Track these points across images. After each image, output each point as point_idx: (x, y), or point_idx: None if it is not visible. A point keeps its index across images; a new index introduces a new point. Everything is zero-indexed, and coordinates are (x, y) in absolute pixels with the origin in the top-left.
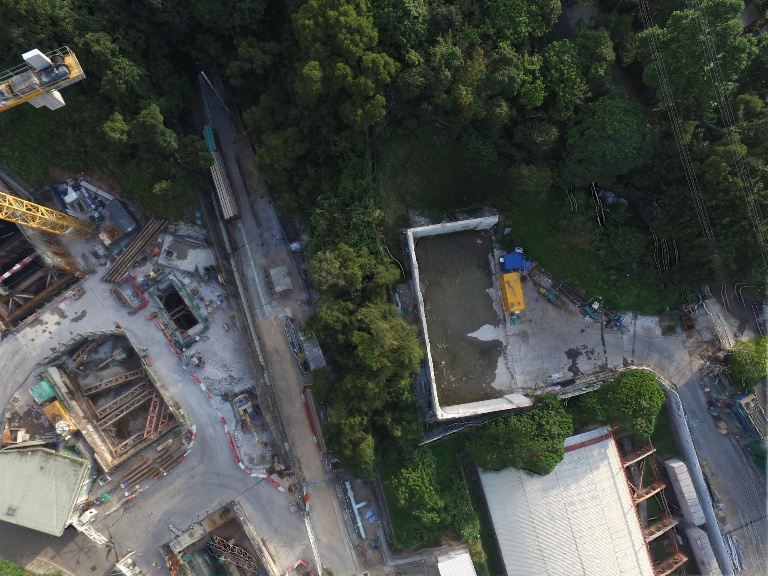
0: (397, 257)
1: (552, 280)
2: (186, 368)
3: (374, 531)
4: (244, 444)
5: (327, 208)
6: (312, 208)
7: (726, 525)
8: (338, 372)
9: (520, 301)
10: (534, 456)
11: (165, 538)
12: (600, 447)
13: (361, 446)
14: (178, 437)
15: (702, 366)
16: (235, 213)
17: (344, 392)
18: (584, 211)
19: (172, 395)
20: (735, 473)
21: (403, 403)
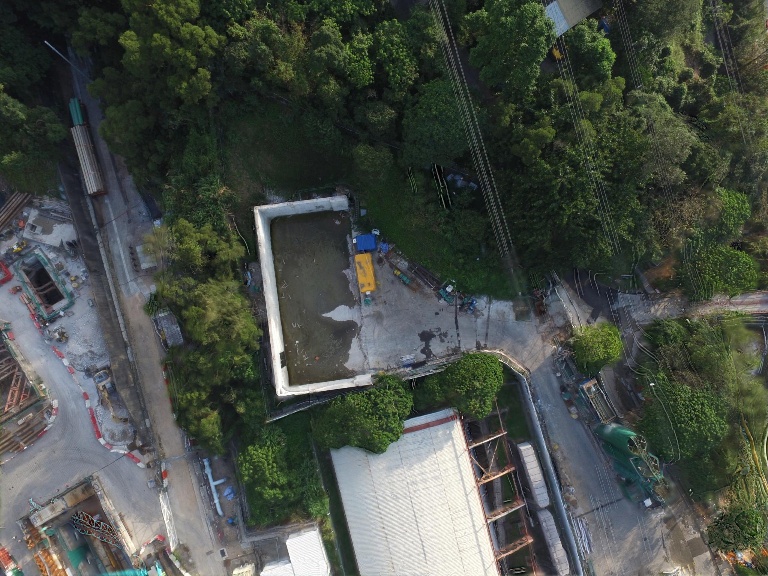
0: (244, 234)
1: (408, 263)
2: (49, 343)
3: (232, 508)
4: (105, 420)
5: (174, 184)
6: (162, 184)
7: (577, 508)
8: (187, 348)
9: (370, 282)
10: (367, 434)
11: (24, 511)
12: (445, 428)
13: (201, 421)
14: (39, 411)
15: (555, 351)
16: (99, 188)
17: (187, 368)
18: (424, 193)
19: (35, 369)
20: (587, 458)
21: (246, 380)
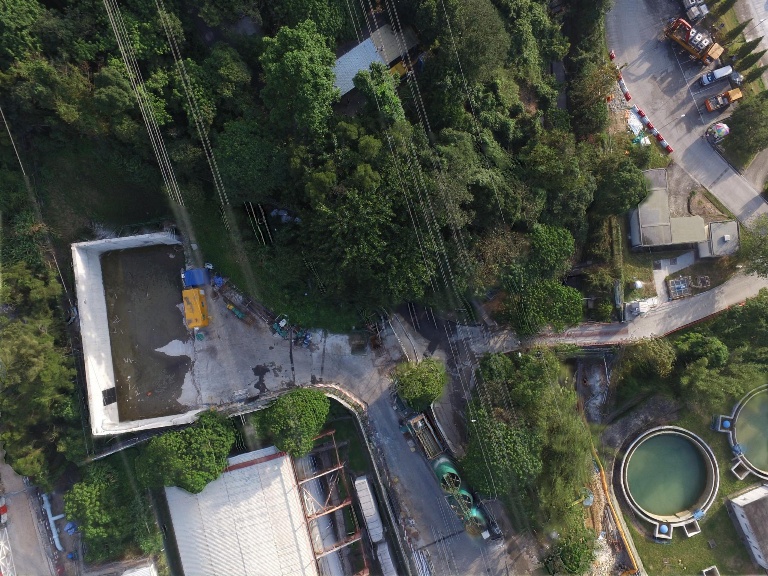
0: (62, 272)
1: (243, 297)
2: None
3: (73, 543)
4: None
5: None
6: None
7: (419, 540)
8: None
9: (198, 318)
10: (181, 474)
11: None
12: (273, 464)
13: None
14: None
15: (391, 385)
16: None
17: None
18: (238, 231)
19: None
20: (428, 490)
21: (66, 418)
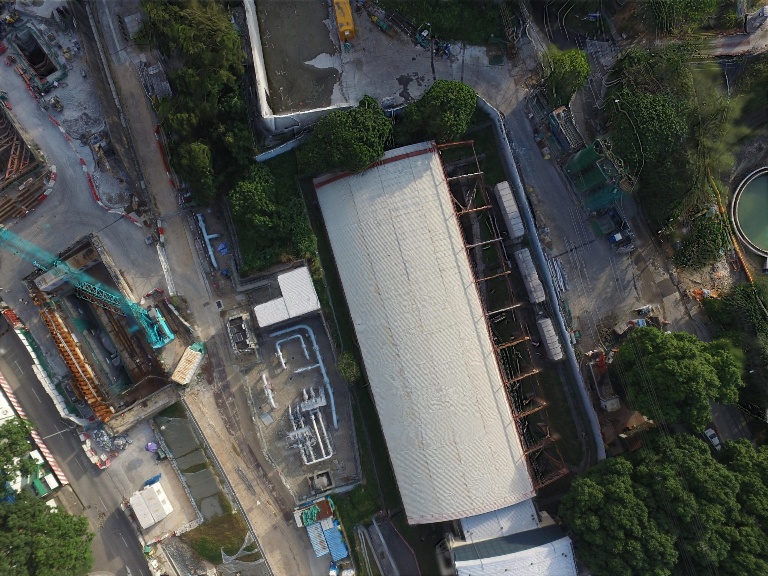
0: None
1: (385, 11)
2: (45, 111)
3: (226, 262)
4: (102, 183)
5: None
6: None
7: (552, 250)
8: (176, 88)
9: (349, 21)
10: (349, 146)
11: (29, 272)
12: (424, 159)
13: (192, 146)
14: (39, 177)
15: (527, 94)
16: None
17: None
18: None
19: (32, 138)
20: (560, 201)
21: (233, 109)
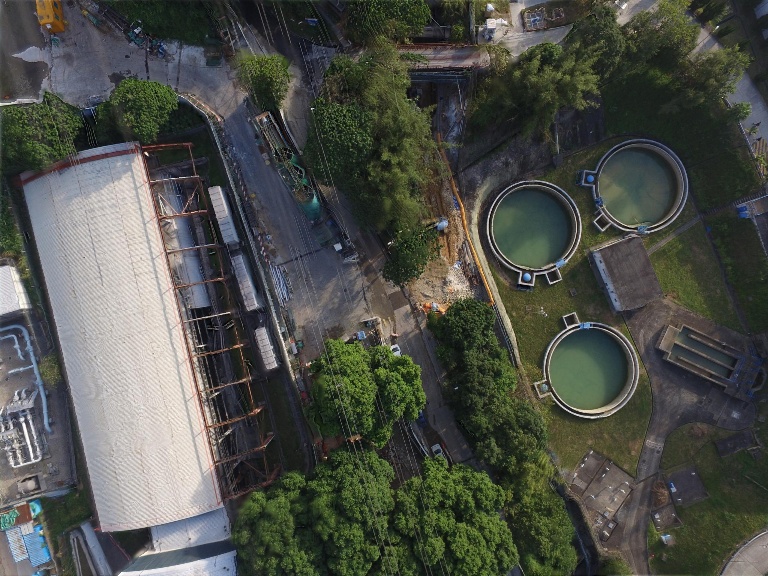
0: None
1: (99, 6)
2: None
3: None
4: None
5: None
6: None
7: (277, 258)
8: None
9: (49, 14)
10: (22, 143)
11: None
12: (124, 160)
13: None
14: None
15: None
16: None
17: None
18: None
19: None
20: (285, 208)
21: None
